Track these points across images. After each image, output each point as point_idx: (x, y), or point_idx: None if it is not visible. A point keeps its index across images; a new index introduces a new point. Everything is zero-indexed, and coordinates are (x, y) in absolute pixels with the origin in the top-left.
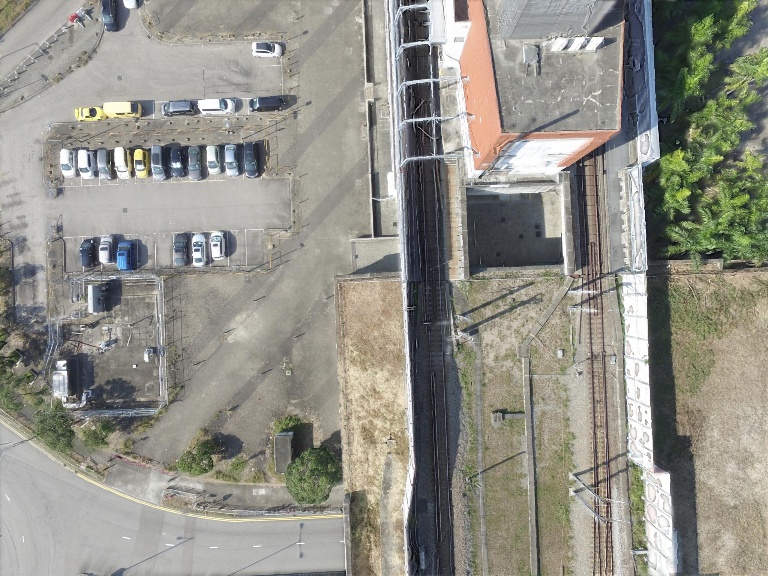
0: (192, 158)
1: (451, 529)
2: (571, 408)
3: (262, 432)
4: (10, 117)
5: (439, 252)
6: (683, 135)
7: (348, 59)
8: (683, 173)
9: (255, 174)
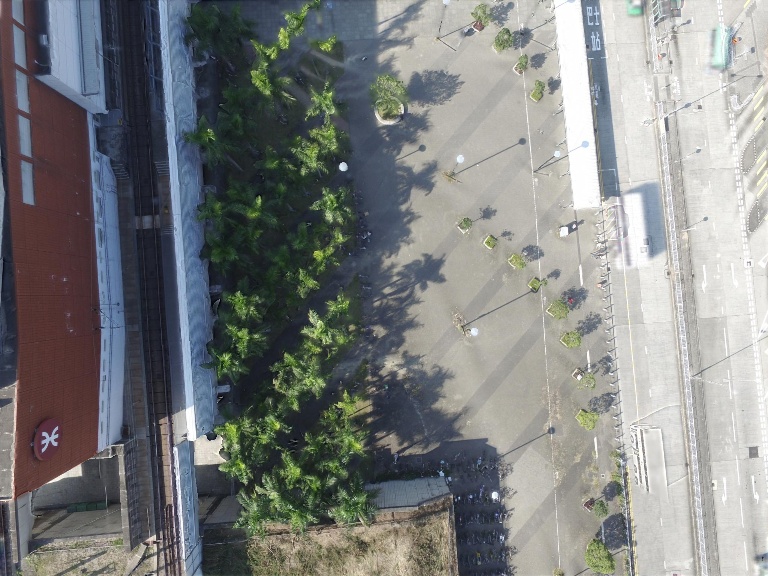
0: None
1: None
2: None
3: None
4: None
5: (4, 524)
6: (267, 385)
7: None
8: (251, 436)
9: None
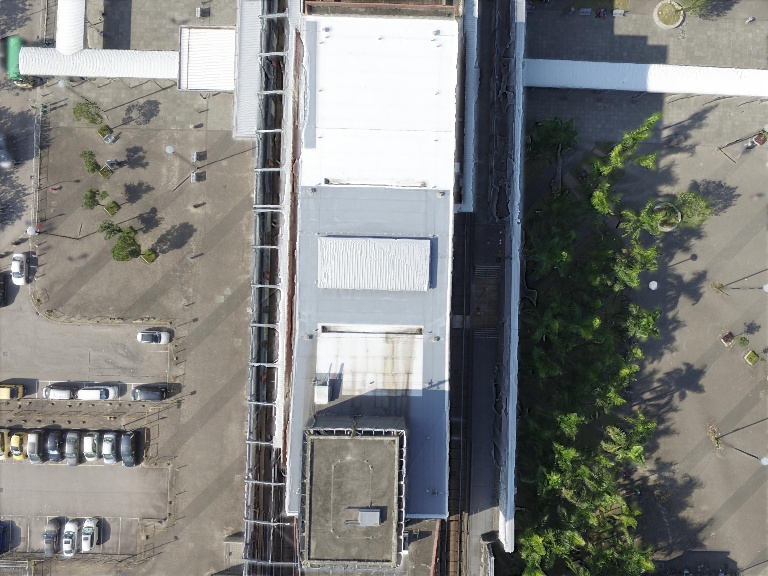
0: (69, 447)
1: None
2: None
3: None
4: None
5: None
6: (556, 492)
7: (236, 350)
8: (547, 545)
9: (132, 465)
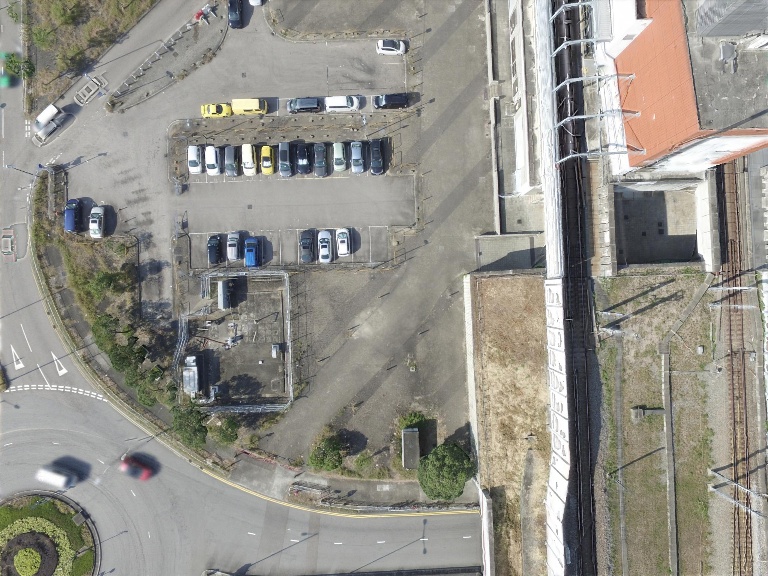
0: (319, 155)
1: (593, 524)
2: (710, 404)
3: (386, 428)
4: (135, 113)
5: (581, 249)
6: None
7: (471, 57)
8: None
9: (381, 171)
